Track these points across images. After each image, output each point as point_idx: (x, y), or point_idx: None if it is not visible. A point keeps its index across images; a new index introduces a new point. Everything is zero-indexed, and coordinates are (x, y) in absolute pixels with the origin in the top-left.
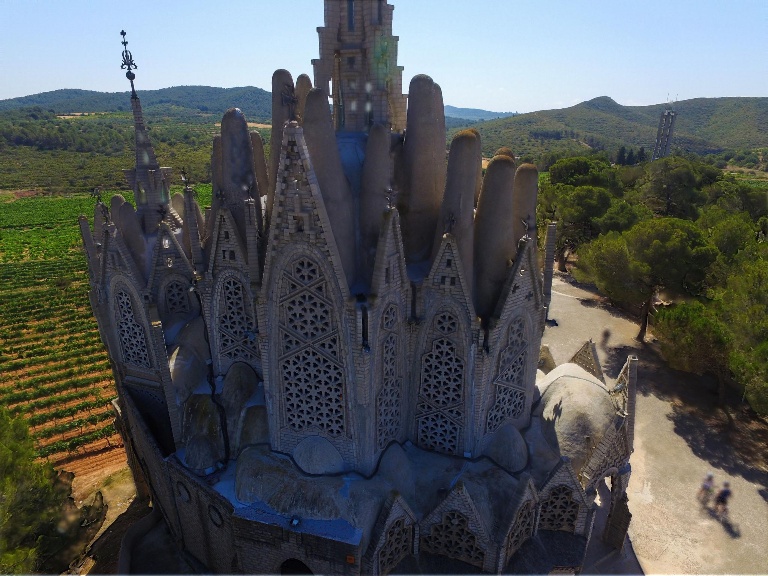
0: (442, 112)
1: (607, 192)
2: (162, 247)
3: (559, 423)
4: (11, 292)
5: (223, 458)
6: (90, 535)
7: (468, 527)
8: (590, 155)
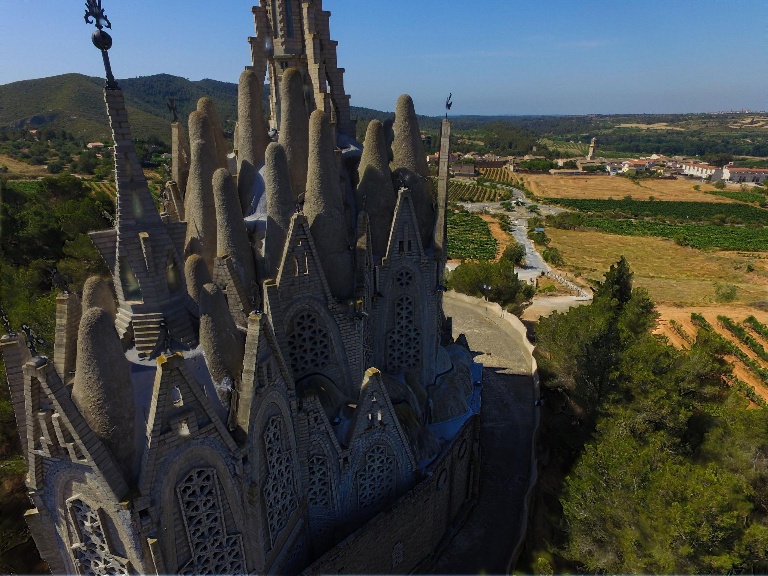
0: None
1: None
2: None
3: None
4: None
5: None
6: None
7: None
8: None
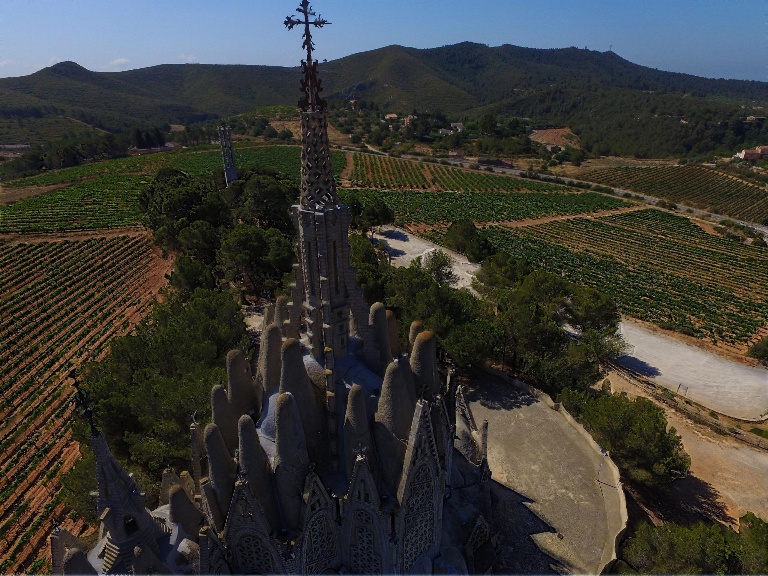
0: None
1: (260, 232)
2: None
3: (456, 443)
4: None
5: None
6: None
7: (481, 529)
8: (107, 141)
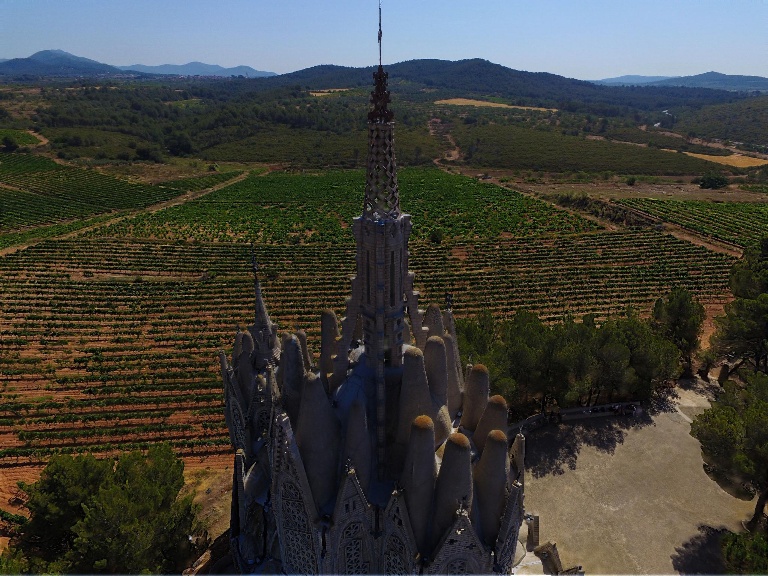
0: (443, 361)
1: None
2: (257, 390)
3: None
4: (241, 276)
5: (261, 555)
6: (198, 556)
7: None
8: None
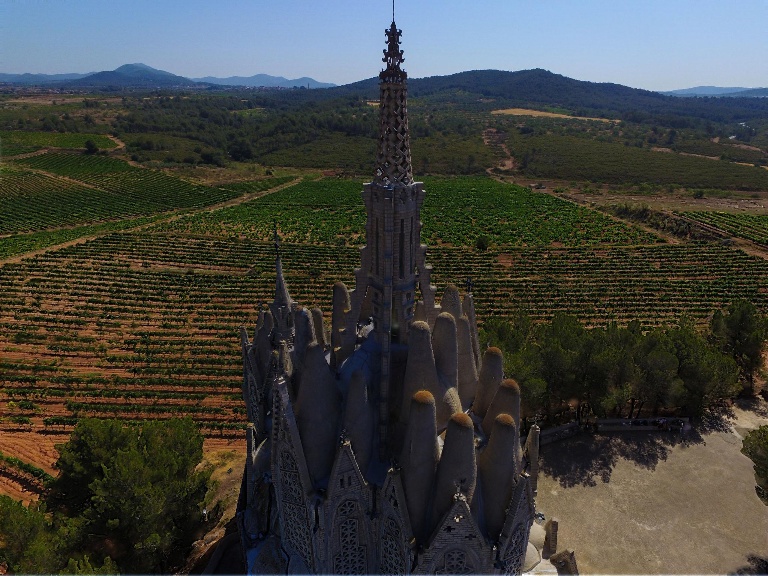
0: (452, 340)
1: None
2: (273, 366)
3: None
4: (285, 273)
5: (265, 531)
6: (209, 529)
7: None
8: None
